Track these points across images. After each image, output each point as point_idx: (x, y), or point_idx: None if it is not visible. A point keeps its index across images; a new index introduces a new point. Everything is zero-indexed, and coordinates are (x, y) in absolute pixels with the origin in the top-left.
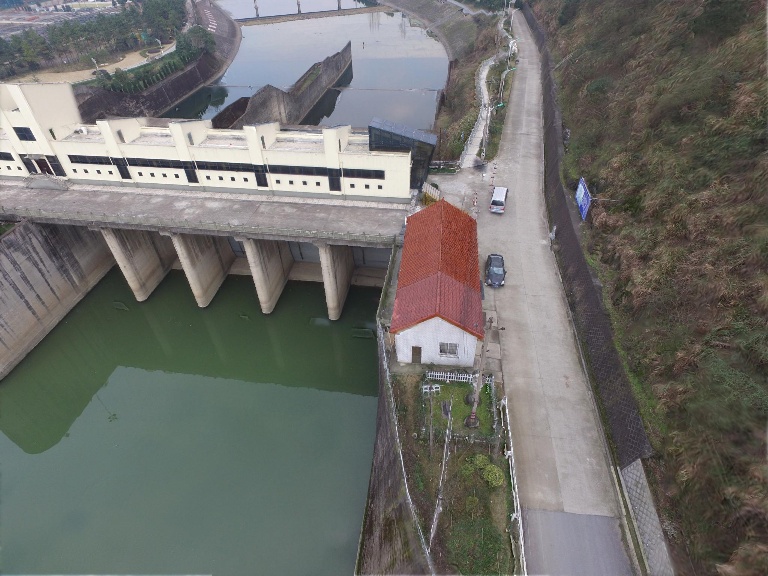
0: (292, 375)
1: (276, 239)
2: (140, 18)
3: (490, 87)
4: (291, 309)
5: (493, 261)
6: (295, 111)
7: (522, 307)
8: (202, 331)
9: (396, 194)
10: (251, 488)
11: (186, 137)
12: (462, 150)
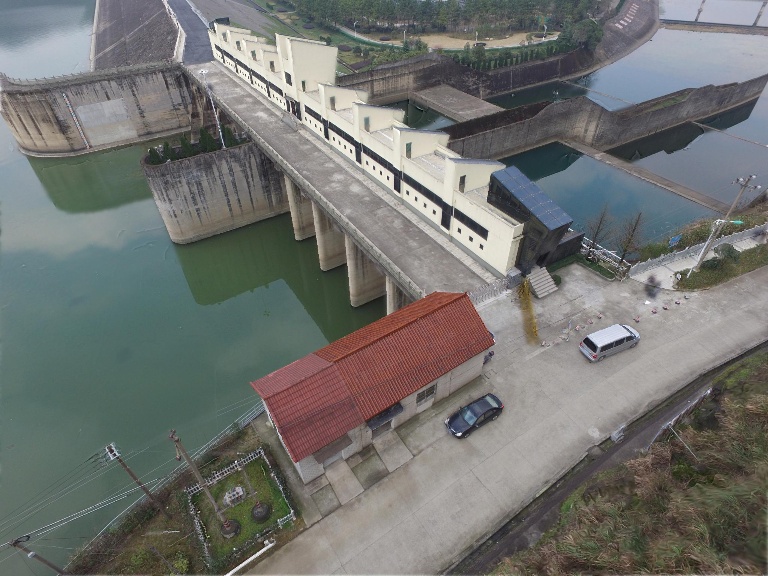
0: None
1: (356, 244)
2: (547, 2)
3: (741, 191)
4: (372, 315)
5: (477, 403)
6: (612, 134)
7: (445, 478)
8: None
9: (494, 263)
10: (197, 425)
11: (362, 120)
12: None
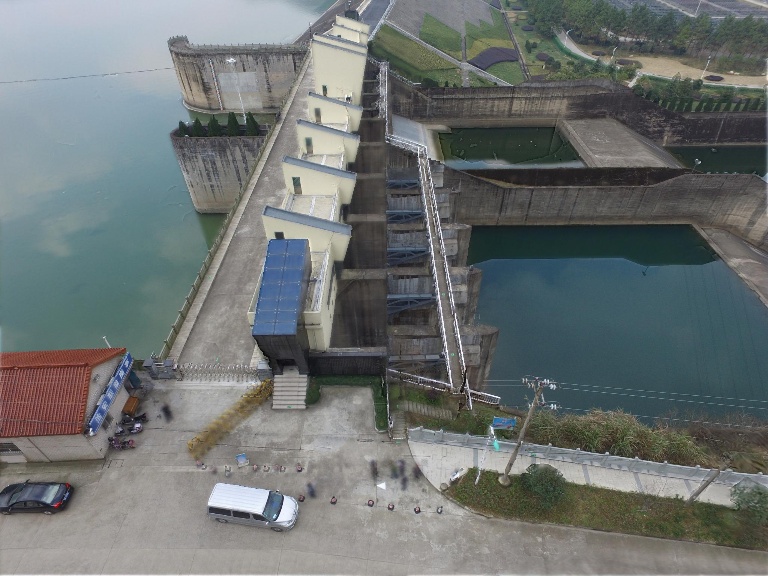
0: None
1: None
2: None
3: None
4: None
5: (35, 486)
6: None
7: None
8: None
9: None
10: None
11: (303, 139)
12: (485, 437)
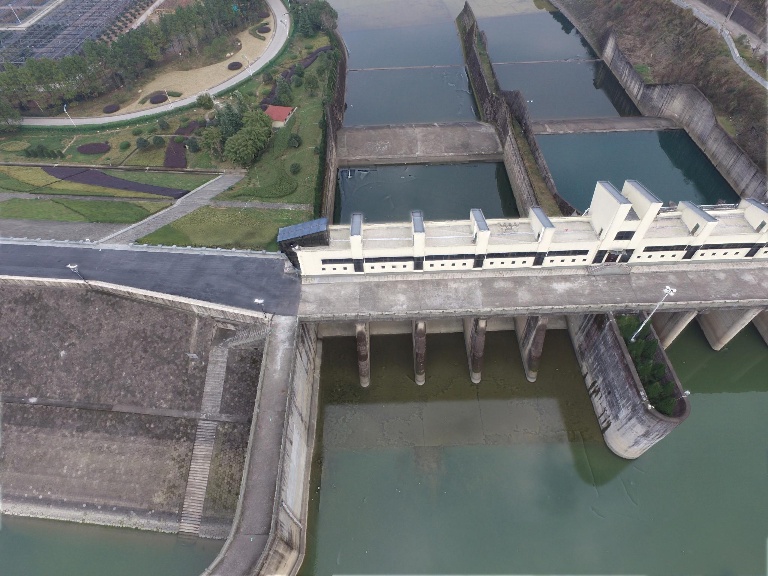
0: (741, 385)
1: None
2: None
3: None
4: None
5: None
6: None
7: None
8: (691, 365)
9: None
10: None
11: None
12: None
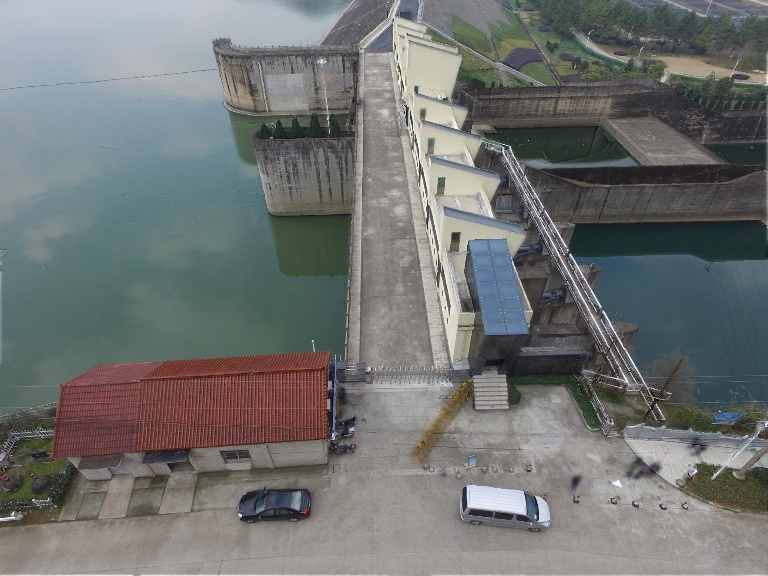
0: None
1: None
2: None
3: None
4: None
5: (279, 493)
6: None
7: (193, 552)
8: None
9: None
10: None
11: (426, 140)
12: None
